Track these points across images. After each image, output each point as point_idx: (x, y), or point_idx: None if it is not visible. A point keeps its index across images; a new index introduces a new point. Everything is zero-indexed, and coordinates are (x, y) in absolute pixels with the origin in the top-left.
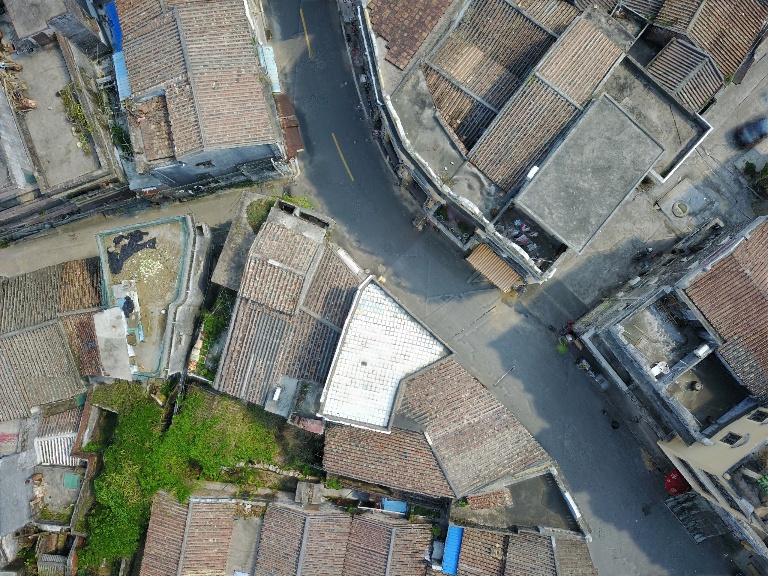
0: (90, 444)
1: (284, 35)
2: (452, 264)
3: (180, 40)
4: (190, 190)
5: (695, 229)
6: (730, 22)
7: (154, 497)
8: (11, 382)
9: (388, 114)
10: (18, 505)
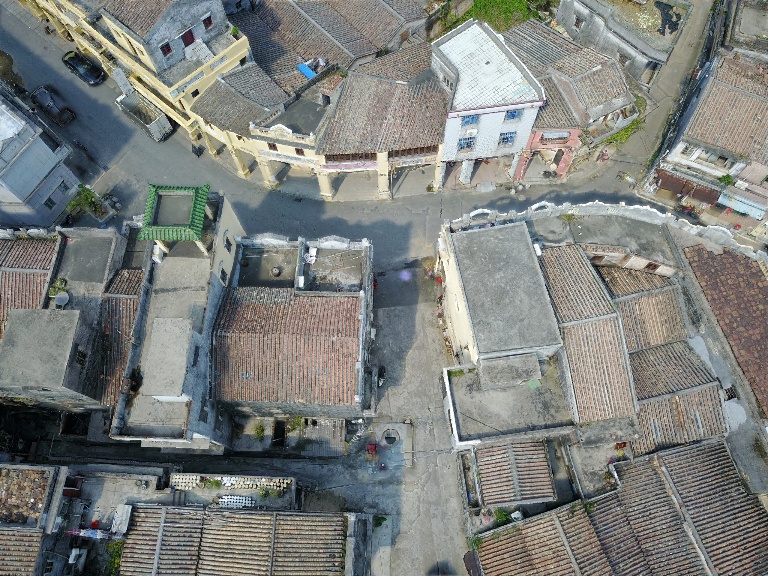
0: None
1: None
2: None
3: None
4: None
5: None
6: None
7: None
8: None
9: None
10: None
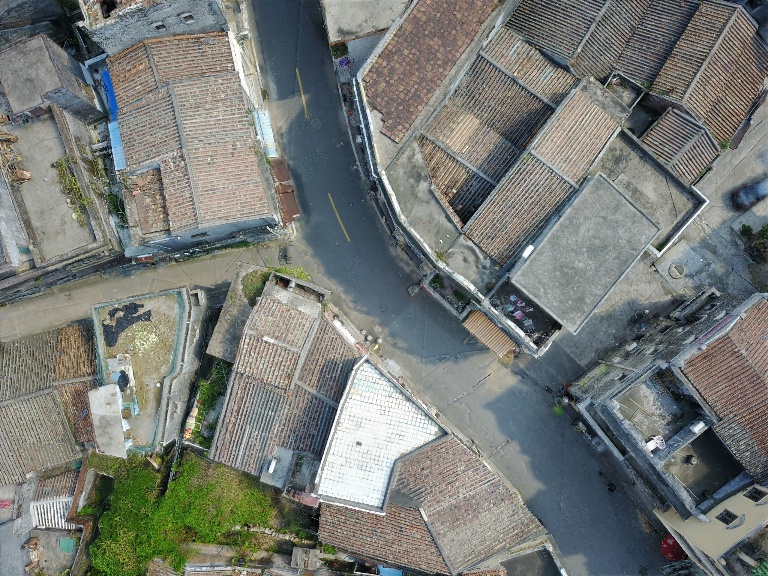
0: (86, 507)
1: (280, 95)
2: (448, 325)
3: (175, 116)
4: (186, 252)
5: (691, 297)
6: (726, 89)
7: (149, 564)
8: (6, 449)
9: (383, 187)
10: (13, 572)
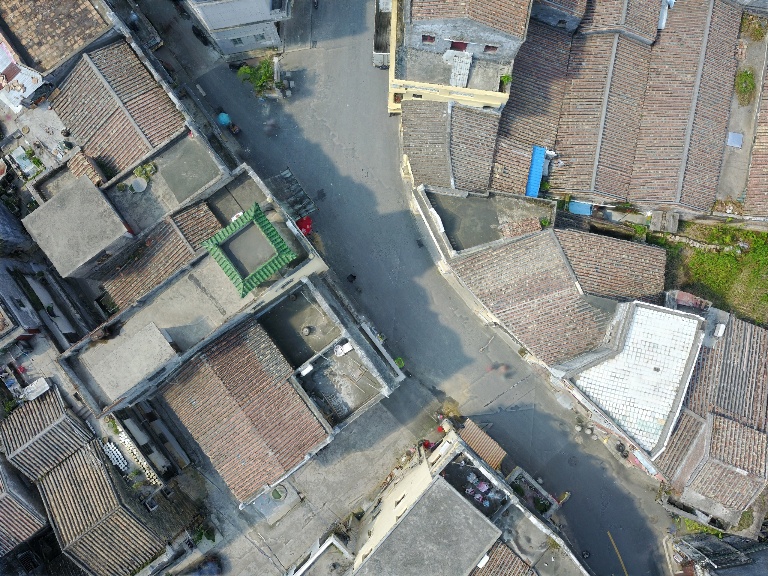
0: None
1: None
2: (508, 442)
3: None
4: None
5: None
6: None
7: None
8: None
9: None
10: None
